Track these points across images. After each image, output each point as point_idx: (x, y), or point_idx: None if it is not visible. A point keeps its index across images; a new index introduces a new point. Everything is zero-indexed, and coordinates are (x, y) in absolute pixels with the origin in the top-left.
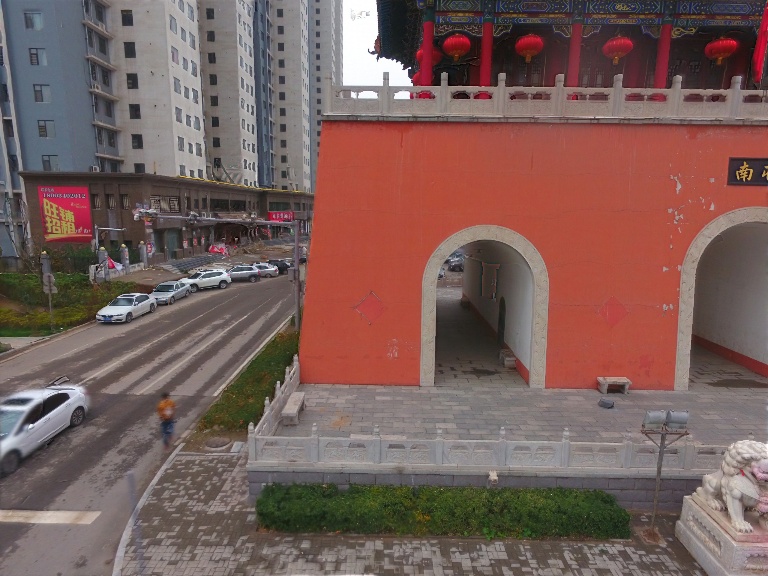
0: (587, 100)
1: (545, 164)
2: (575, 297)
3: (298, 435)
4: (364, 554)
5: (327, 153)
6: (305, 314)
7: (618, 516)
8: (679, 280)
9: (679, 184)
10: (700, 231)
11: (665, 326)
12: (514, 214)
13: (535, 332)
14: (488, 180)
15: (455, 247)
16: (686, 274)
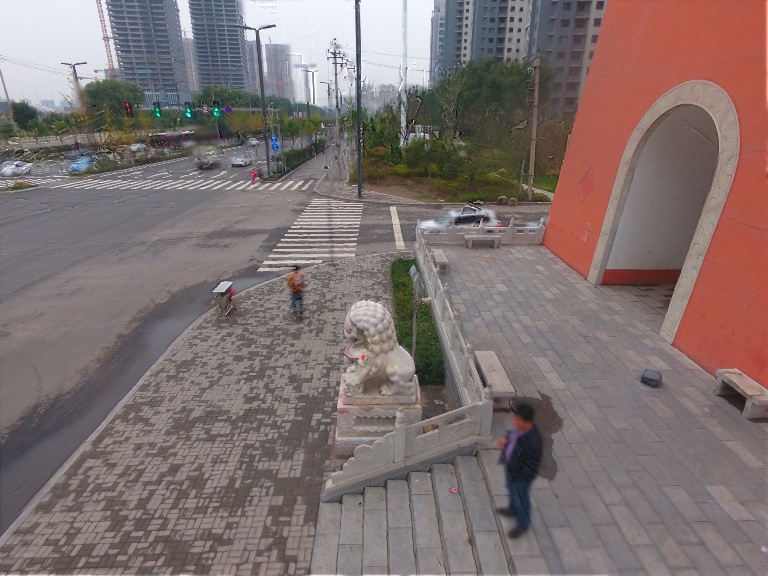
0: None
1: None
2: (763, 212)
3: (454, 249)
4: (378, 293)
5: (608, 14)
6: (558, 184)
7: None
8: None
9: None
10: None
11: None
12: (731, 57)
13: (690, 256)
14: (720, 4)
15: (656, 116)
16: None
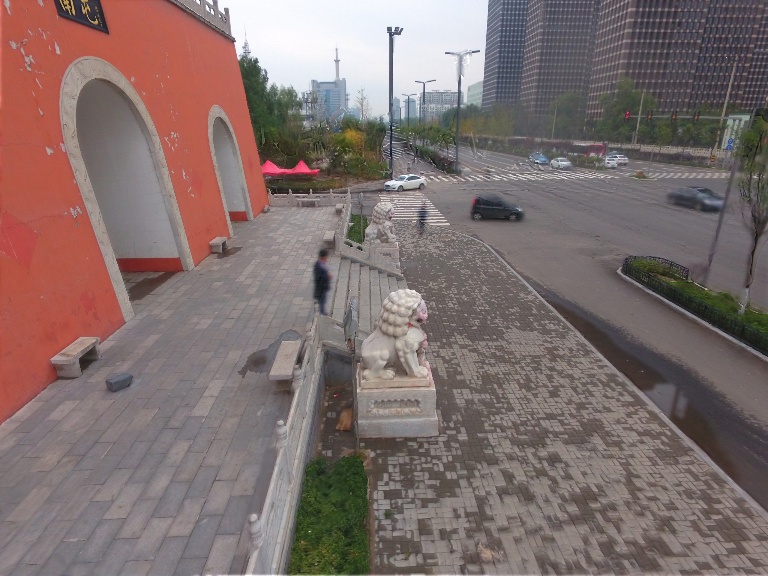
0: None
1: None
2: None
3: None
4: None
5: None
6: None
7: (361, 466)
8: (70, 167)
9: None
10: (60, 87)
11: (84, 241)
12: None
13: None
14: None
15: None
16: (73, 157)
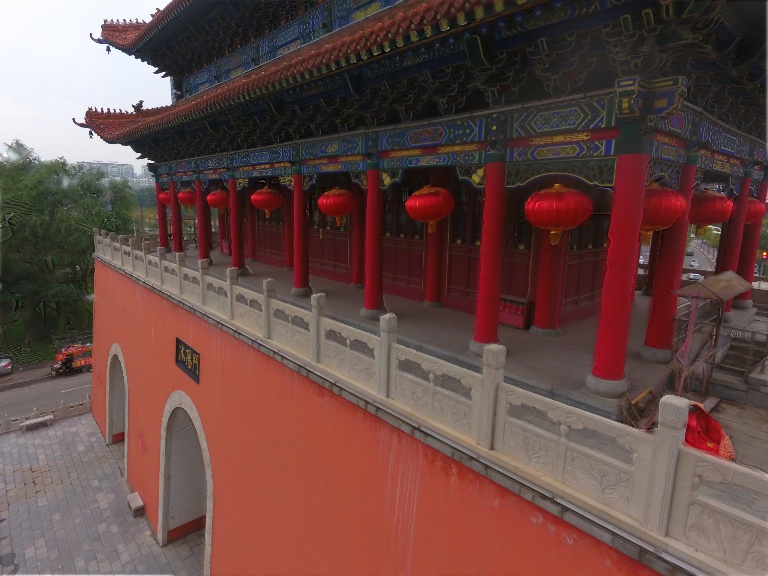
0: None
1: None
2: None
3: None
4: None
5: None
6: None
7: None
8: None
9: None
10: None
11: None
12: None
13: None
14: None
15: None
16: None
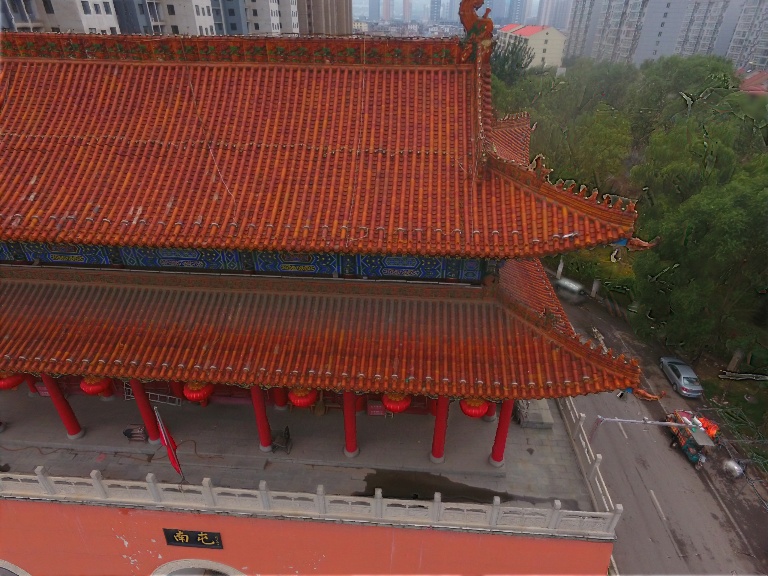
0: (20, 482)
1: (5, 521)
2: None
3: None
4: None
5: None
6: None
7: None
8: None
9: (126, 541)
10: (155, 570)
11: None
12: None
13: None
14: None
15: None
16: None
